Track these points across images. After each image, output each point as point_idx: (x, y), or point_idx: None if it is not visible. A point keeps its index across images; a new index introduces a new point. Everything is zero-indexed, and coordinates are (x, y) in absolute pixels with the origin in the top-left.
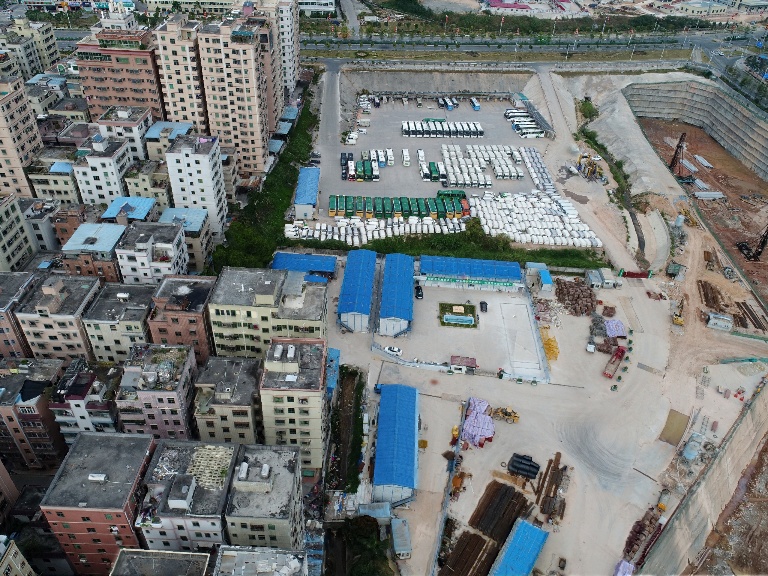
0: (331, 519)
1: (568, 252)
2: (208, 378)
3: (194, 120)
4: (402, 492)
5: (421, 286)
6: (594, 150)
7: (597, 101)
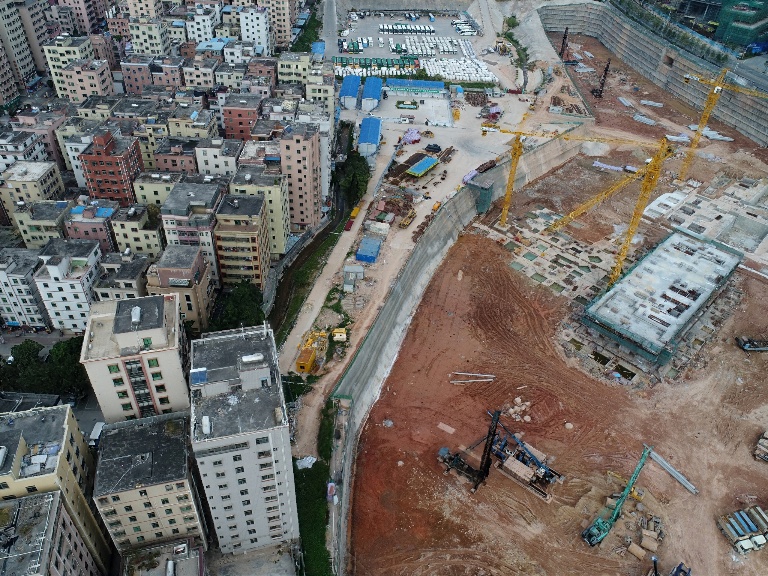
0: (338, 161)
1: (477, 84)
2: None
3: (248, 5)
4: (372, 148)
5: (387, 95)
6: (509, 42)
7: (520, 18)
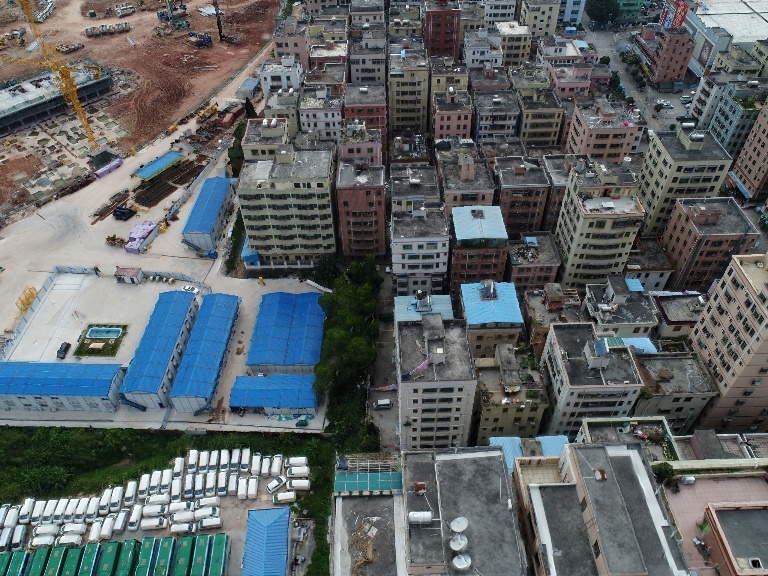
0: None
1: None
2: (327, 145)
3: None
4: None
5: None
6: None
7: None
